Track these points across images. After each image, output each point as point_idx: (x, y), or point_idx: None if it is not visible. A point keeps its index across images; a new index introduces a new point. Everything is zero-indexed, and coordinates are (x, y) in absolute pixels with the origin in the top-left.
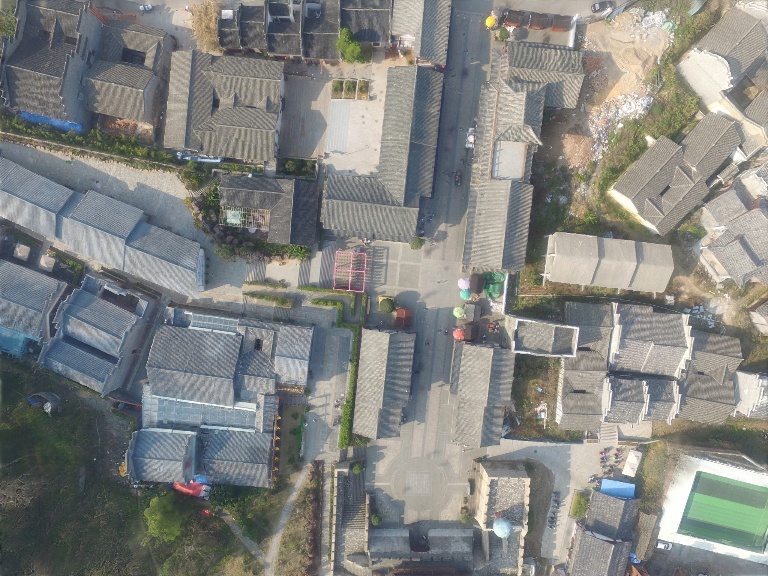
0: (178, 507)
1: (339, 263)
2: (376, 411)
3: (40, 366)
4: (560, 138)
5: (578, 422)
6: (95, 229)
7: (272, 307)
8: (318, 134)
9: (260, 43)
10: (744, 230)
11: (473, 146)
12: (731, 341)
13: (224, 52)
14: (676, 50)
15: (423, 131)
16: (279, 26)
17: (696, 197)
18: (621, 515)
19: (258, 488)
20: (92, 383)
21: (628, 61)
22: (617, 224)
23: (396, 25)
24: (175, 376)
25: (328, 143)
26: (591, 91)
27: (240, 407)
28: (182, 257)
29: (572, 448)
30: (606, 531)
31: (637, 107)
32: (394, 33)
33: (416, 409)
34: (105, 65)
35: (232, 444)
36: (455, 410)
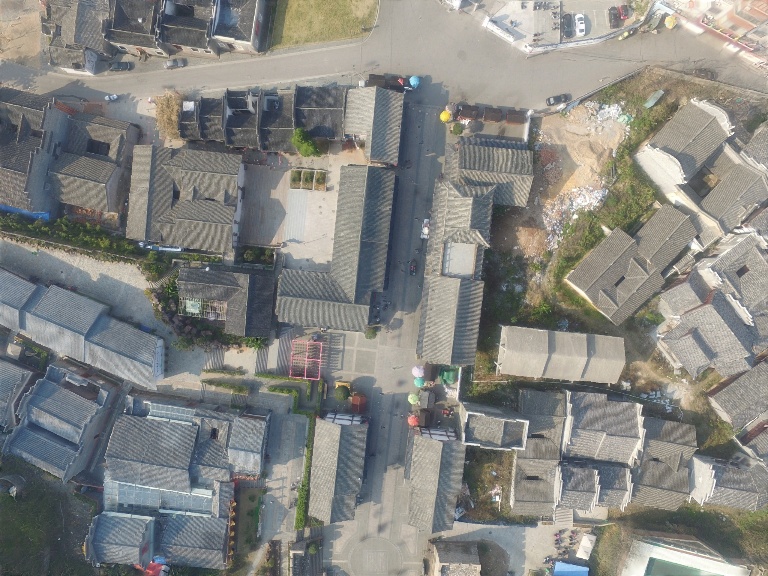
0: None
1: (295, 351)
2: (330, 496)
3: (5, 454)
4: (514, 231)
5: (530, 508)
6: (56, 325)
7: (230, 394)
8: (277, 222)
9: (220, 135)
10: (698, 323)
11: (428, 237)
12: (686, 429)
13: (186, 141)
14: (633, 141)
15: (374, 229)
16: (238, 119)
17: (651, 288)
18: None
19: None
20: (54, 470)
21: (583, 154)
22: (573, 312)
23: (348, 125)
24: (133, 465)
25: (287, 231)
26: (545, 185)
27: (197, 494)
28: (139, 351)
29: (527, 529)
30: None
31: (591, 200)
32: (347, 133)
33: (372, 490)
34: (70, 158)
35: (189, 529)
36: (410, 492)
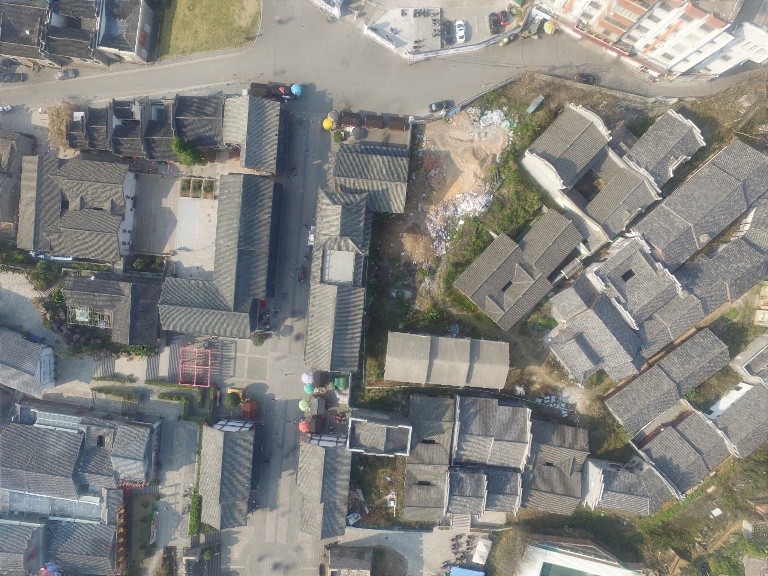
0: None
1: (185, 358)
2: None
3: None
4: (398, 237)
5: (421, 514)
6: None
7: (120, 402)
8: (169, 230)
9: None
10: (583, 328)
11: None
12: (579, 433)
13: (80, 151)
14: (518, 146)
15: (253, 237)
16: (125, 129)
17: (538, 293)
18: None
19: None
20: None
21: (466, 160)
22: (463, 317)
23: (226, 134)
24: (18, 473)
25: (178, 239)
26: (428, 191)
27: (84, 501)
28: (22, 360)
29: (424, 534)
30: None
31: (475, 206)
32: (224, 141)
33: (268, 496)
34: None
35: (77, 536)
36: None
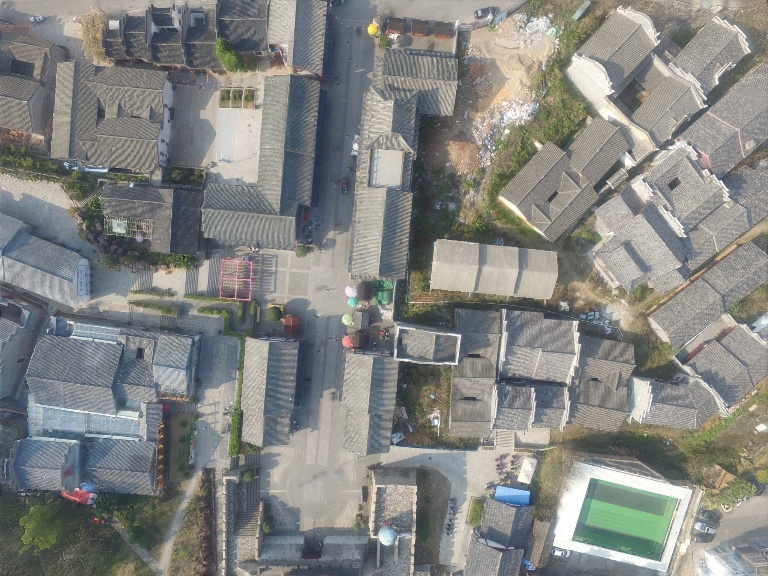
0: (63, 515)
1: (225, 271)
2: (262, 419)
3: None
4: (444, 145)
5: (467, 429)
6: None
7: (158, 316)
8: (207, 143)
9: (146, 53)
10: (630, 236)
11: None
12: (625, 347)
13: (114, 62)
14: (563, 55)
15: (300, 140)
16: (163, 36)
17: (584, 203)
18: (513, 522)
19: (147, 496)
20: None
21: (512, 67)
22: (508, 230)
23: (271, 34)
24: (55, 385)
25: (217, 152)
26: (474, 98)
27: (123, 416)
28: (60, 267)
29: (468, 455)
30: (499, 538)
31: (522, 113)
32: (270, 42)
33: (309, 416)
34: None
35: (115, 452)
36: None
